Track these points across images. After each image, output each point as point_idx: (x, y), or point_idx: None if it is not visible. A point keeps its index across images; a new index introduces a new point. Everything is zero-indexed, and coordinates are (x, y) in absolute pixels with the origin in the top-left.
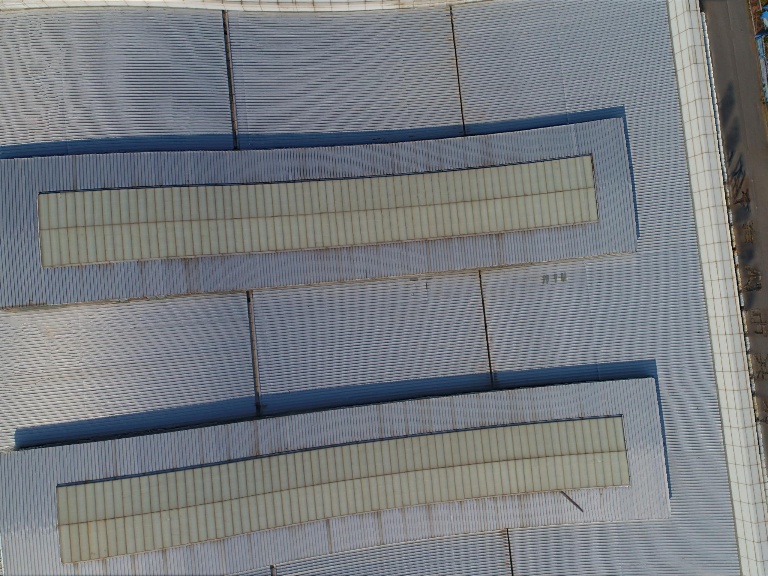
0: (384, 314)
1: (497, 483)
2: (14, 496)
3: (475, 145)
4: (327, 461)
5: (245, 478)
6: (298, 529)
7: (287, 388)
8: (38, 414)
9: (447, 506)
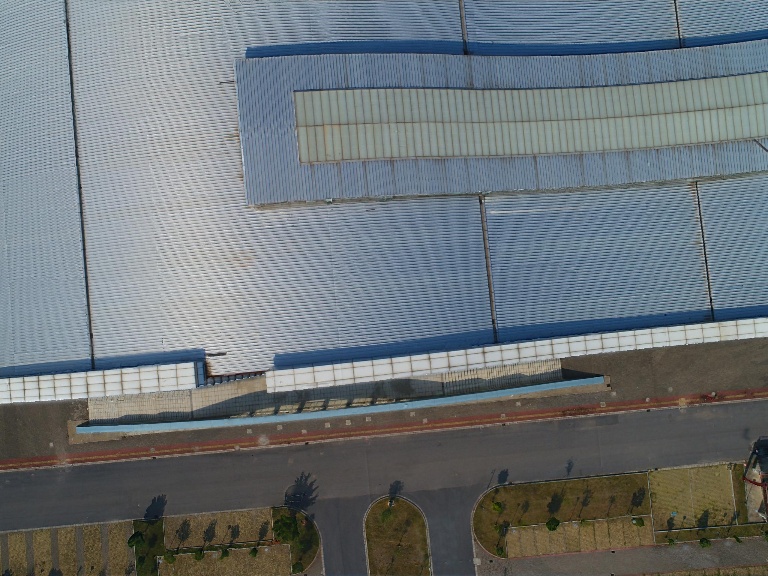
0: None
1: (692, 132)
2: (253, 99)
3: None
4: (534, 101)
5: (462, 105)
6: (509, 161)
7: (491, 39)
8: (267, 35)
9: (644, 153)
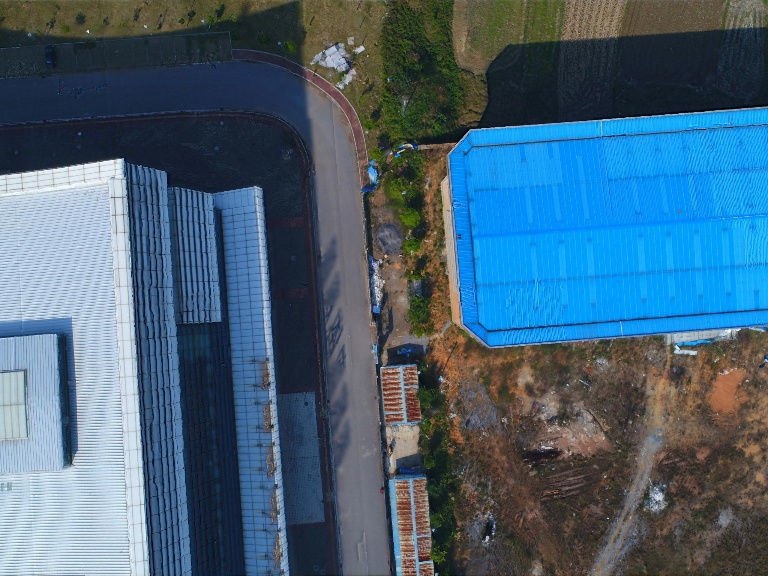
0: None
1: None
2: None
3: None
4: None
5: None
6: None
7: None
8: None
9: None
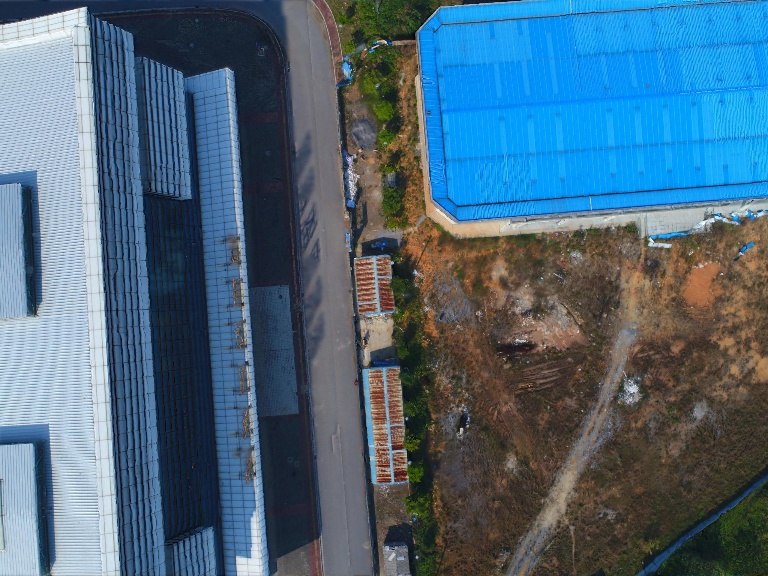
0: None
1: None
2: None
3: None
4: None
5: None
6: None
7: None
8: None
9: None
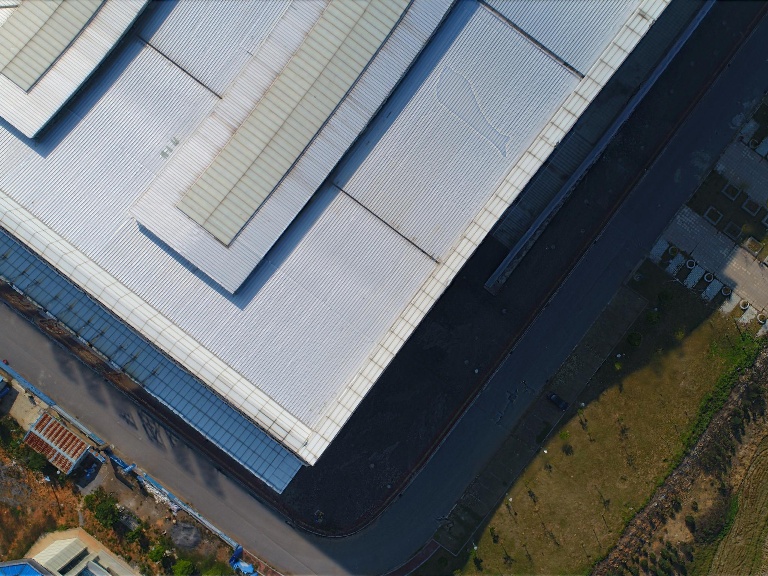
0: (257, 3)
1: None
2: None
3: (315, 176)
4: None
5: None
6: None
7: None
8: None
9: None
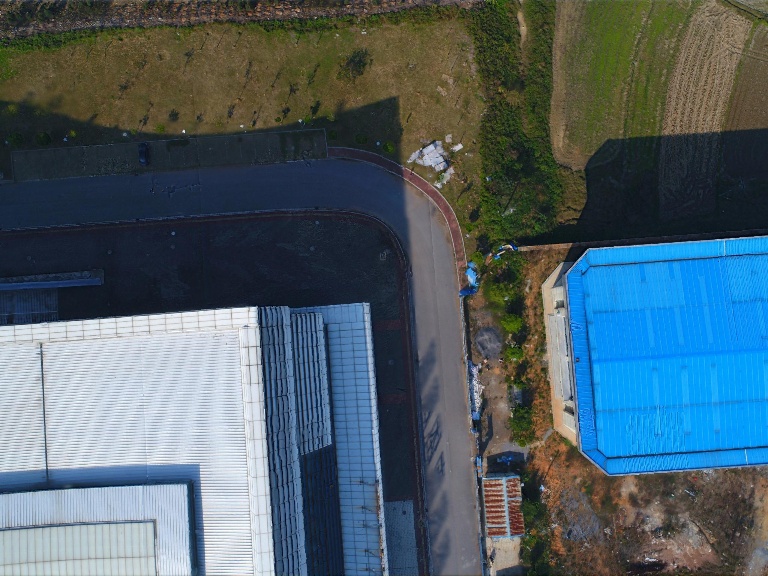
0: None
1: None
2: None
3: (45, 501)
4: None
5: None
6: None
7: None
8: None
9: None
